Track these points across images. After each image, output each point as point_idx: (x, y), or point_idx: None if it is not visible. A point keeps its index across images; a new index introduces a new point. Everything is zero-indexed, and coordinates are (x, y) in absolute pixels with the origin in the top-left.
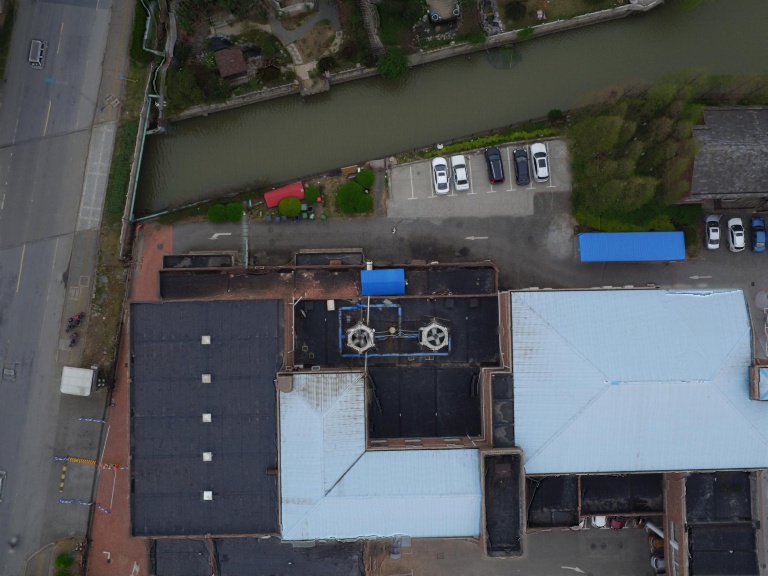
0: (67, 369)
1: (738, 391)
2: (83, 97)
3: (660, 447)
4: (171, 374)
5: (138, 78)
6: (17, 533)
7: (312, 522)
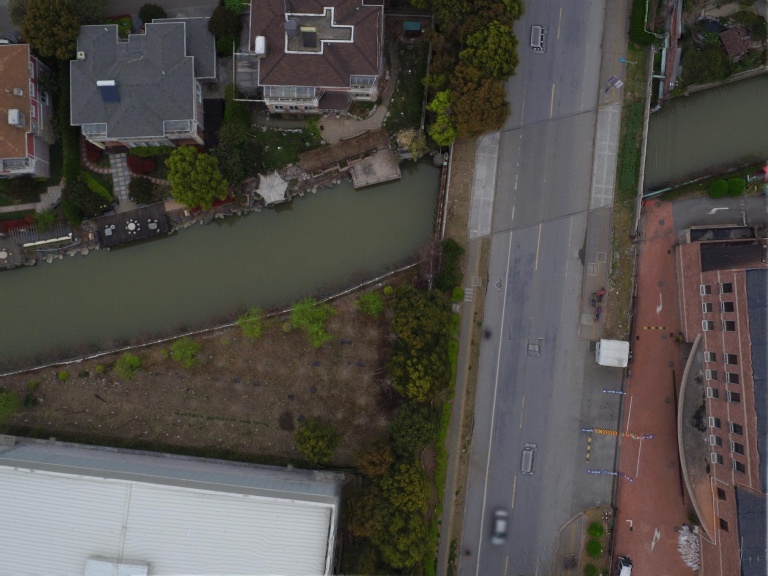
0: (604, 342)
1: None
2: (585, 79)
3: None
4: None
5: (637, 60)
6: (549, 504)
7: None
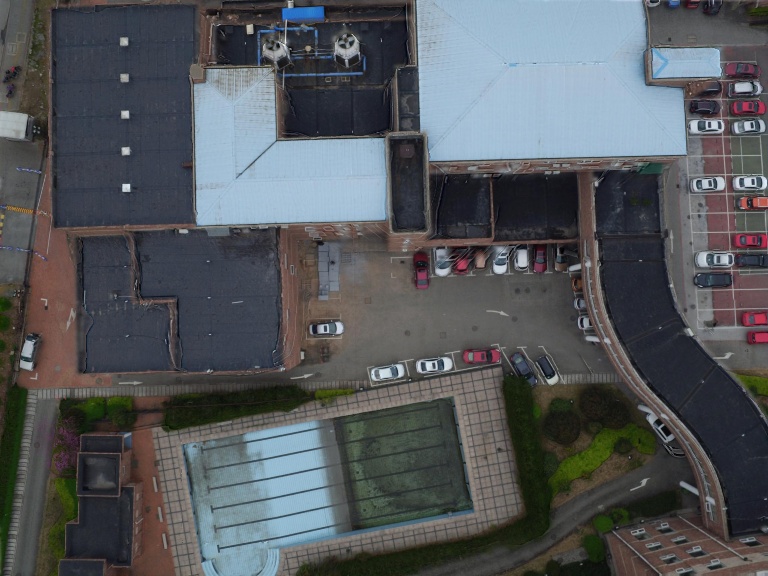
0: (3, 114)
1: (634, 76)
2: None
3: (560, 133)
4: (91, 76)
5: None
6: None
7: (225, 207)
